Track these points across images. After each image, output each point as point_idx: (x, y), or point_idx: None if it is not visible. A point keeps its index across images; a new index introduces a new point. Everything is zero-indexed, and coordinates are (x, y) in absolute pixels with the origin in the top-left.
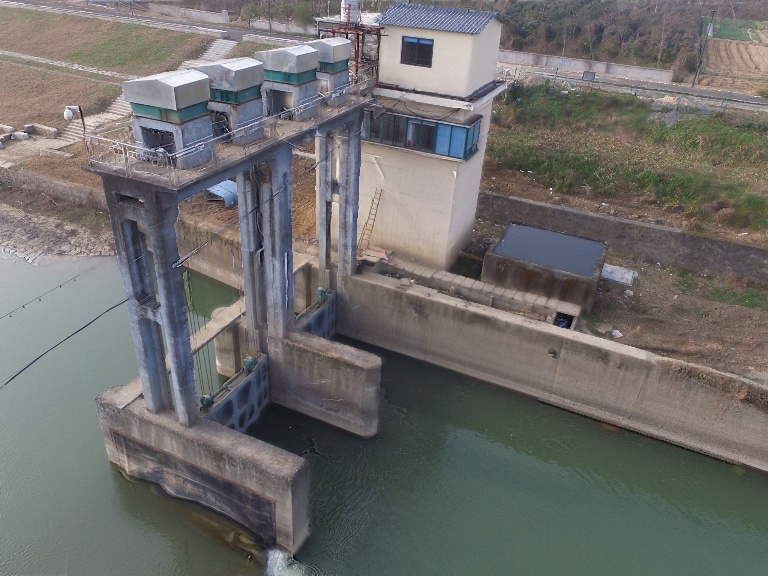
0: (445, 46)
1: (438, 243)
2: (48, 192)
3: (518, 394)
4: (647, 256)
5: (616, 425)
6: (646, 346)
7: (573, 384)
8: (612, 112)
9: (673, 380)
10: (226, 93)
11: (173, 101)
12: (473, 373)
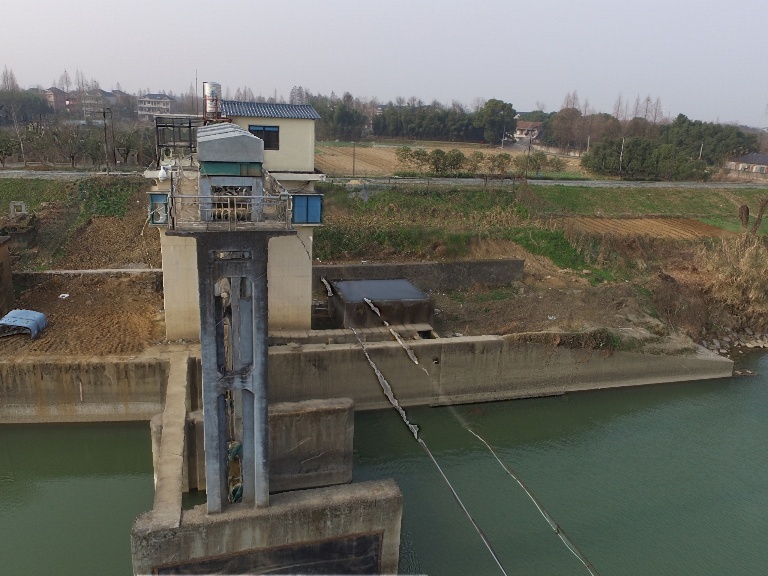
0: (290, 131)
1: (303, 305)
2: None
3: (414, 408)
4: (422, 287)
5: (487, 401)
6: None
7: (454, 380)
8: None
9: (517, 348)
10: None
11: (262, 154)
12: (374, 406)
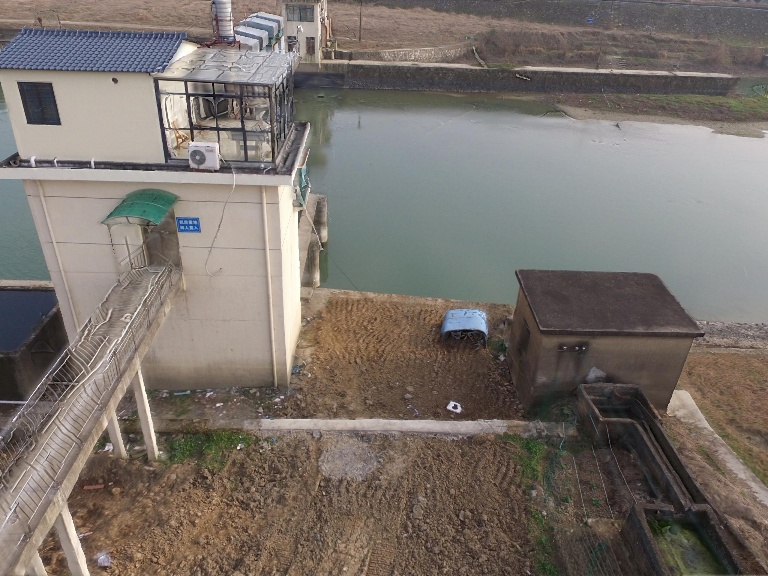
0: None
1: None
2: None
3: None
4: None
5: None
6: None
7: None
8: None
9: None
10: None
11: None
12: None
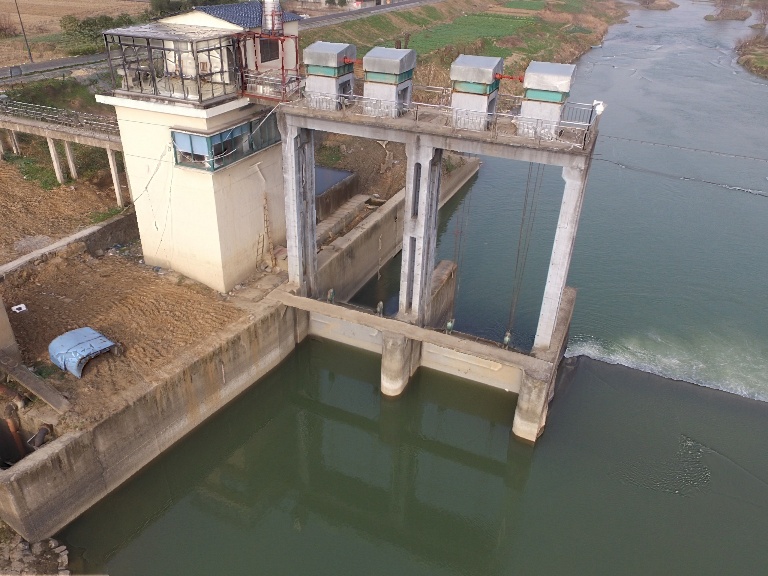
0: None
1: None
2: None
3: None
4: None
5: None
6: (387, 191)
7: None
8: (65, 98)
9: None
10: None
11: None
12: None
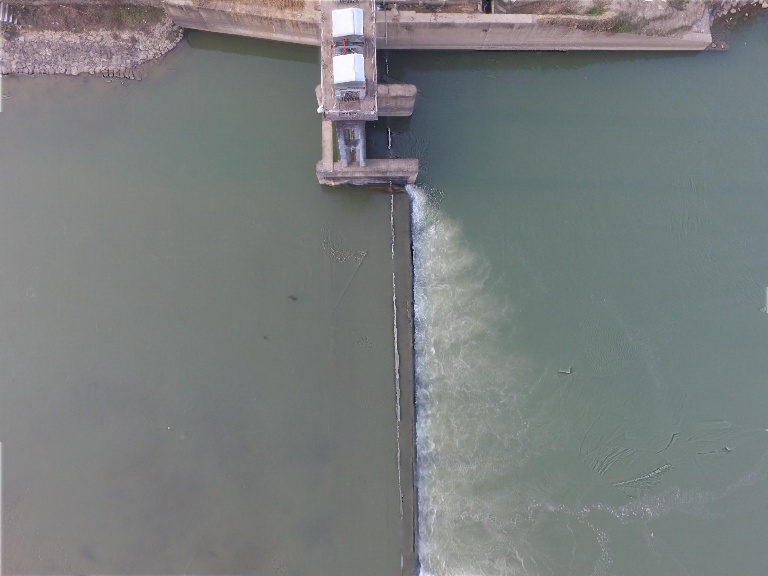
0: None
1: None
2: (64, 3)
3: (464, 50)
4: None
5: (514, 50)
6: (529, 3)
7: (494, 40)
8: None
9: (544, 28)
10: (356, 42)
11: (364, 85)
12: (440, 48)
